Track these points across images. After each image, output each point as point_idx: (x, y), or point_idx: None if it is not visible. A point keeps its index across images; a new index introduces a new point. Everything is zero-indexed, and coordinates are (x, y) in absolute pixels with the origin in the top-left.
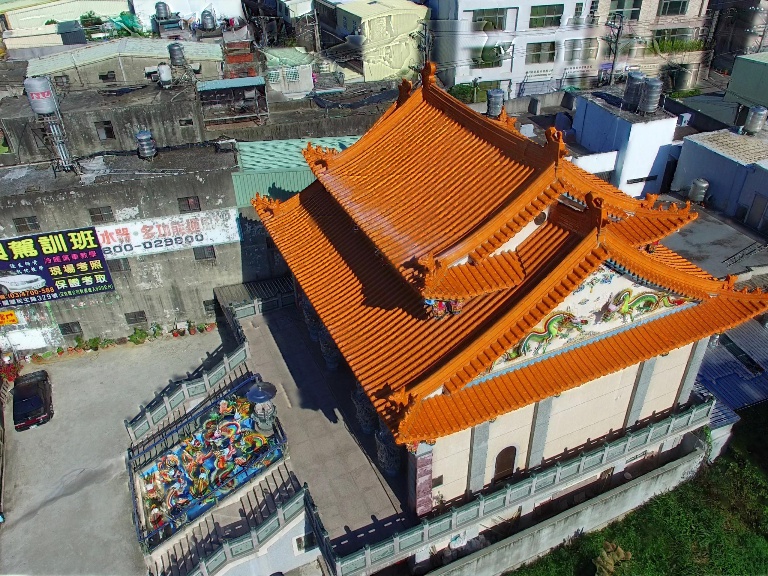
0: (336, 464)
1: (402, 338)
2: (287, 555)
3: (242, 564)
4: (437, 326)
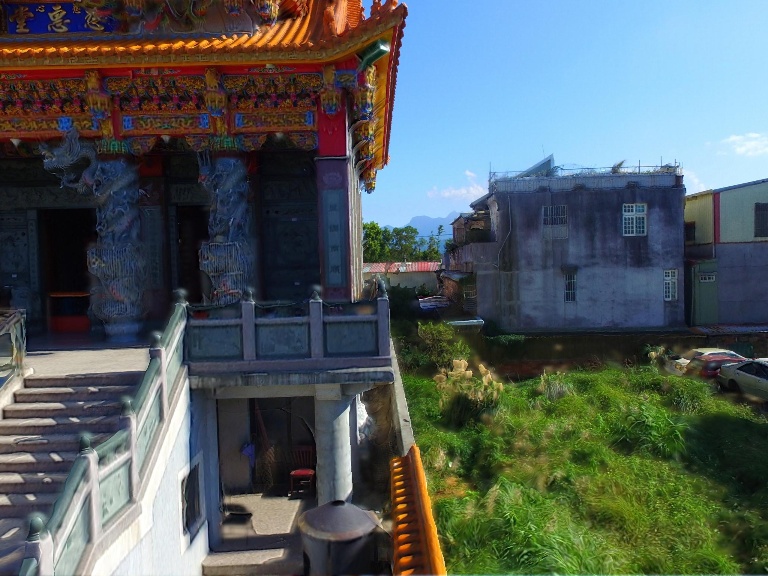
0: (140, 356)
1: (225, 45)
2: (172, 549)
3: (117, 571)
4: (258, 38)
